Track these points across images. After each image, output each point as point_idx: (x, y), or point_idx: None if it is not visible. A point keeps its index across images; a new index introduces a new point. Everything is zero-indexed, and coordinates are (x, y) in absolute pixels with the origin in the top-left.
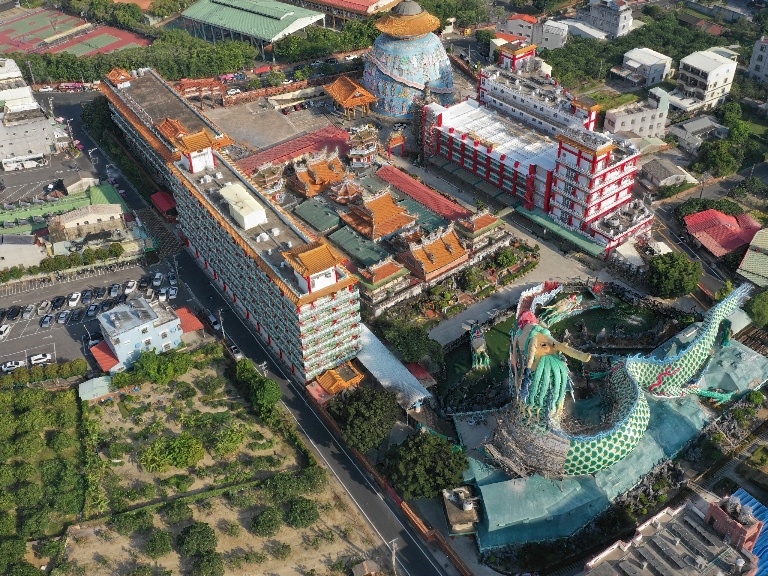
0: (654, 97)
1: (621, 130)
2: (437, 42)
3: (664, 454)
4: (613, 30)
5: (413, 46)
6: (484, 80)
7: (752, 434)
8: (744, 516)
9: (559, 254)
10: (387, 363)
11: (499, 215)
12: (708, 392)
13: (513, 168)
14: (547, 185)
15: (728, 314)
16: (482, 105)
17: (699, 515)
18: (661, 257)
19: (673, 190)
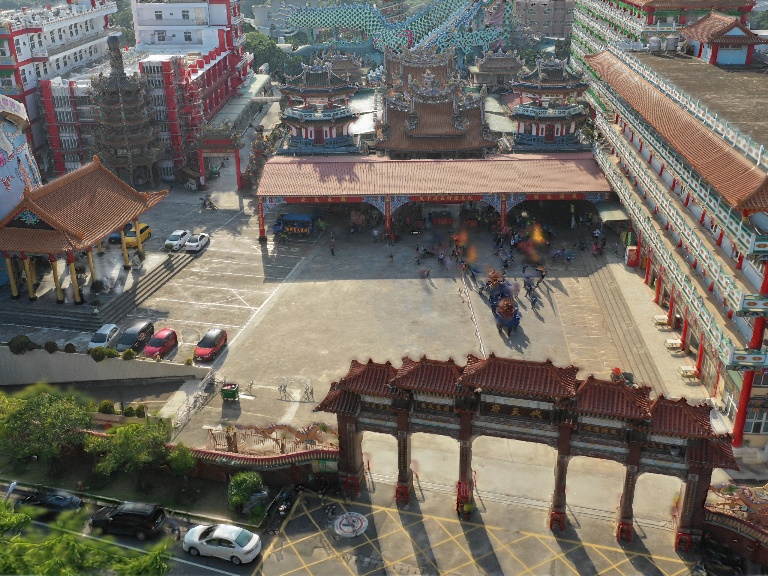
0: None
1: None
2: None
3: None
4: None
5: None
6: (19, 42)
7: None
8: None
9: (274, 103)
10: None
11: (318, 59)
12: None
13: None
14: None
15: (295, 31)
16: (61, 79)
17: None
18: None
19: None
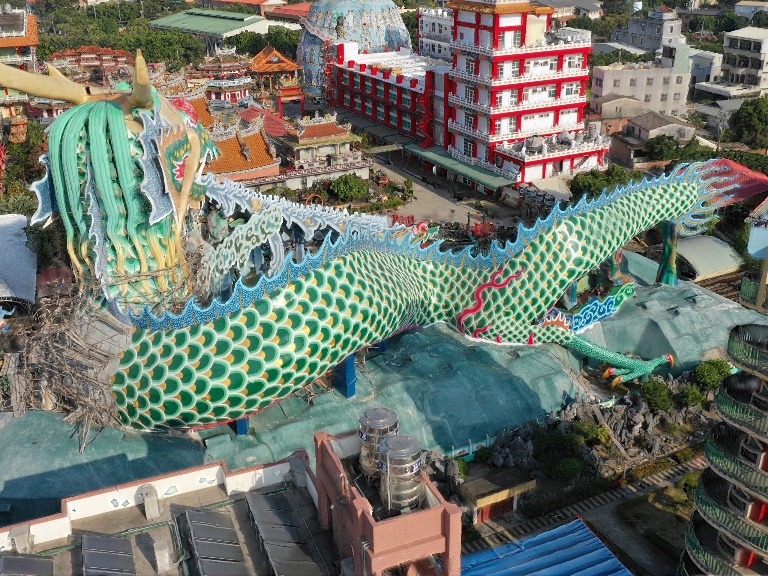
0: (669, 55)
1: (614, 93)
2: (388, 3)
3: (432, 441)
4: (655, 45)
5: (351, 1)
6: (422, 22)
7: (689, 447)
8: (383, 470)
9: (448, 200)
10: (3, 254)
11: (350, 124)
12: (594, 345)
13: (407, 88)
14: (445, 99)
15: (681, 227)
16: (415, 53)
17: (314, 502)
18: (591, 172)
19: (668, 143)
